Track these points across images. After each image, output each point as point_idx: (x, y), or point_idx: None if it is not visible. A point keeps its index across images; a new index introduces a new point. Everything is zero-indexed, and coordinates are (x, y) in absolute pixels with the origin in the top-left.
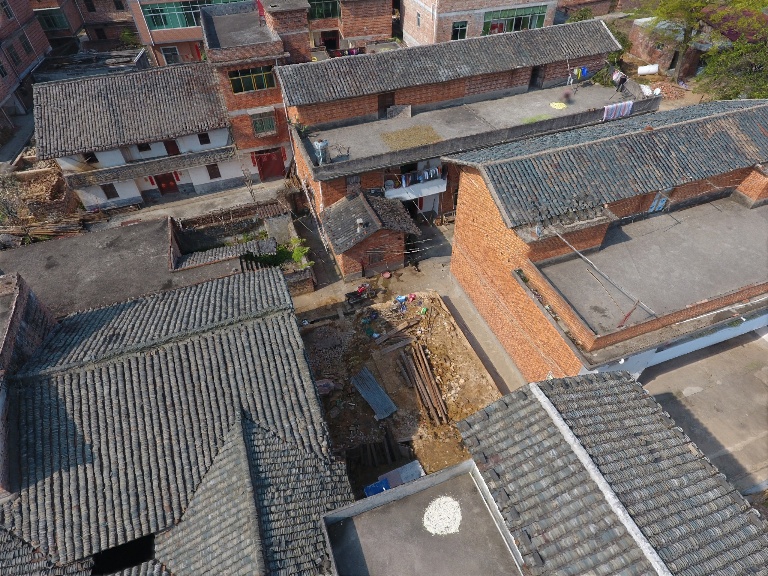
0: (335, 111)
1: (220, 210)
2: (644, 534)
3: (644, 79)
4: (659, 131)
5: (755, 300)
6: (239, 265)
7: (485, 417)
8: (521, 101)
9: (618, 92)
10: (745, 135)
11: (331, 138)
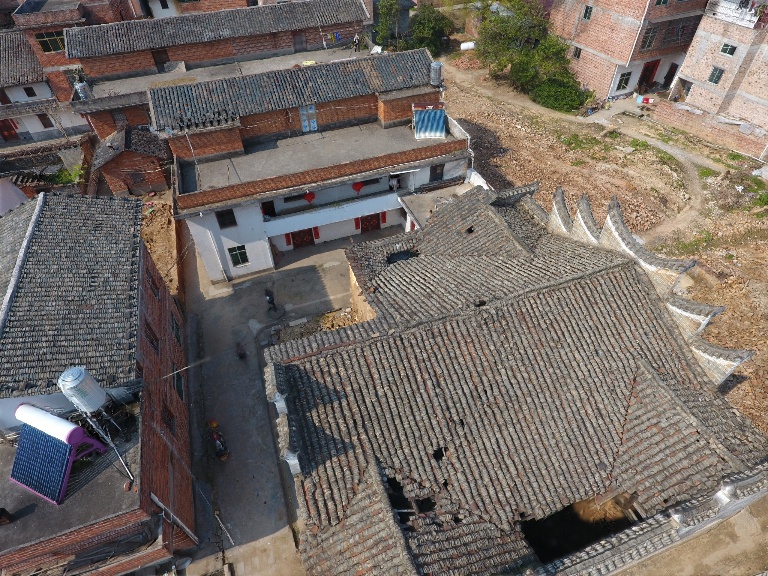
0: (116, 65)
1: (34, 147)
2: (30, 248)
3: (460, 53)
4: (306, 68)
5: (327, 181)
6: (14, 178)
7: (9, 211)
8: (283, 60)
9: (366, 53)
10: (376, 72)
11: (111, 86)
